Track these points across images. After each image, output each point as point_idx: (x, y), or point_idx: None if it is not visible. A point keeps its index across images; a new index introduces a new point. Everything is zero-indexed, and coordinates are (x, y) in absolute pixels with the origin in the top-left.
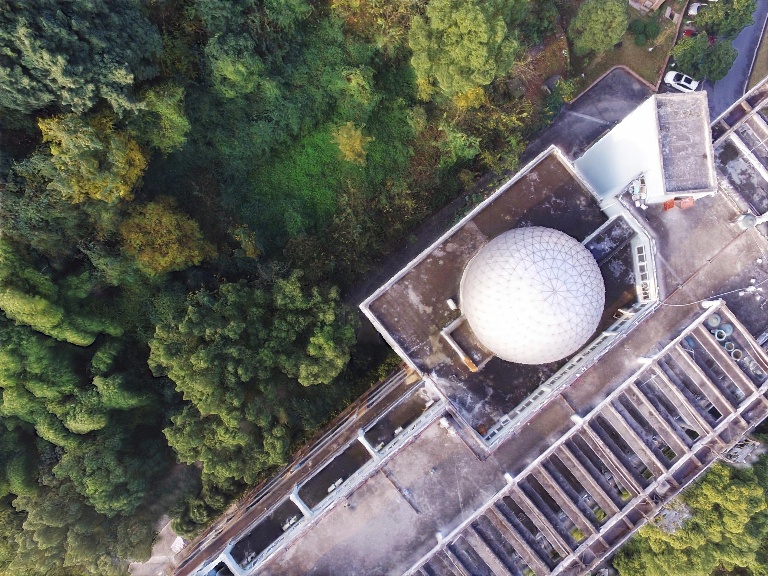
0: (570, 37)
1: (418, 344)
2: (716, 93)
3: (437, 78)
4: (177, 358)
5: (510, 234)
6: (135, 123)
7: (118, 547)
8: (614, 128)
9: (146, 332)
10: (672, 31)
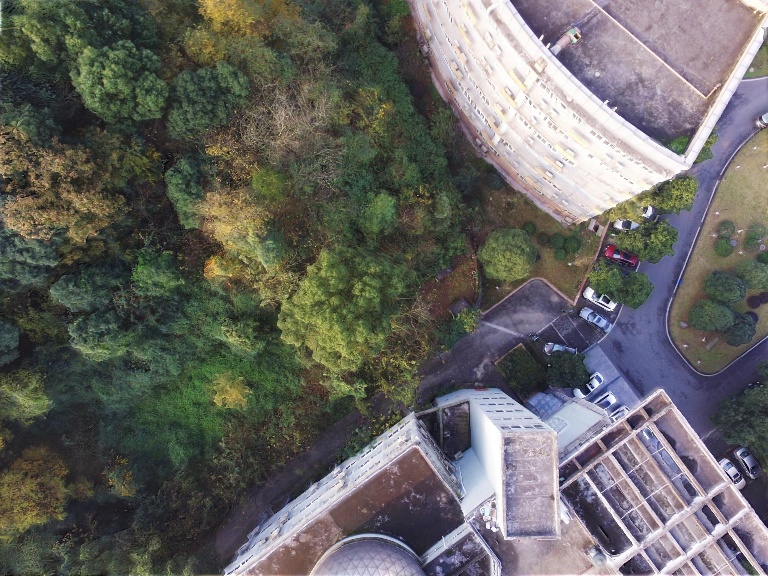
0: (479, 260)
1: None
2: (638, 309)
3: None
4: None
5: (341, 572)
6: None
7: None
8: (485, 416)
9: (13, 575)
10: (595, 244)
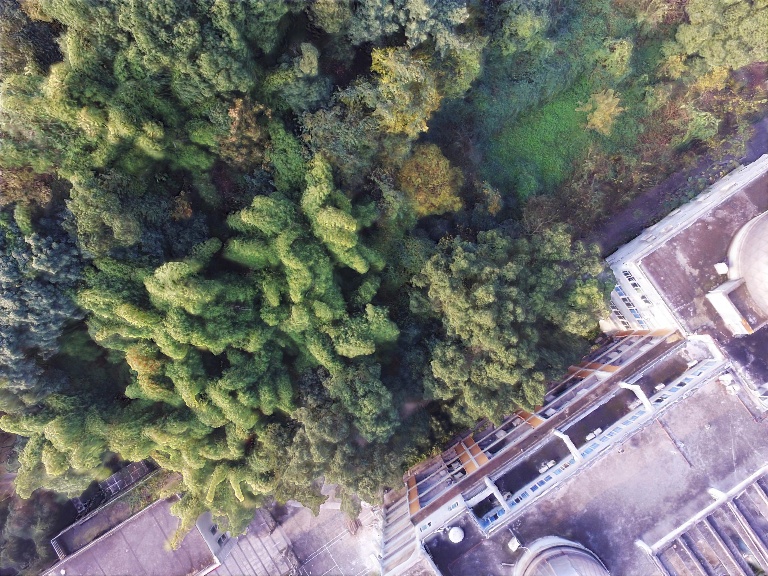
0: None
1: (682, 304)
2: None
3: (703, 54)
4: (458, 291)
5: None
6: (435, 66)
7: (380, 471)
8: None
9: (395, 271)
10: None
